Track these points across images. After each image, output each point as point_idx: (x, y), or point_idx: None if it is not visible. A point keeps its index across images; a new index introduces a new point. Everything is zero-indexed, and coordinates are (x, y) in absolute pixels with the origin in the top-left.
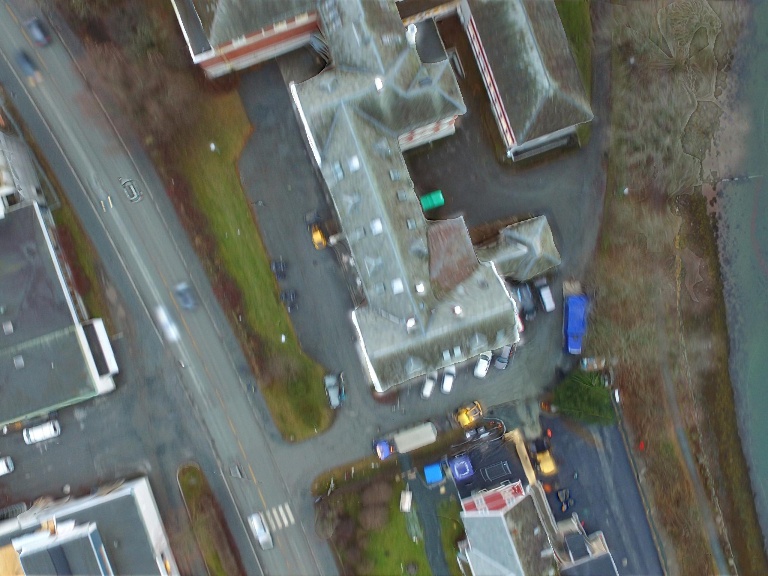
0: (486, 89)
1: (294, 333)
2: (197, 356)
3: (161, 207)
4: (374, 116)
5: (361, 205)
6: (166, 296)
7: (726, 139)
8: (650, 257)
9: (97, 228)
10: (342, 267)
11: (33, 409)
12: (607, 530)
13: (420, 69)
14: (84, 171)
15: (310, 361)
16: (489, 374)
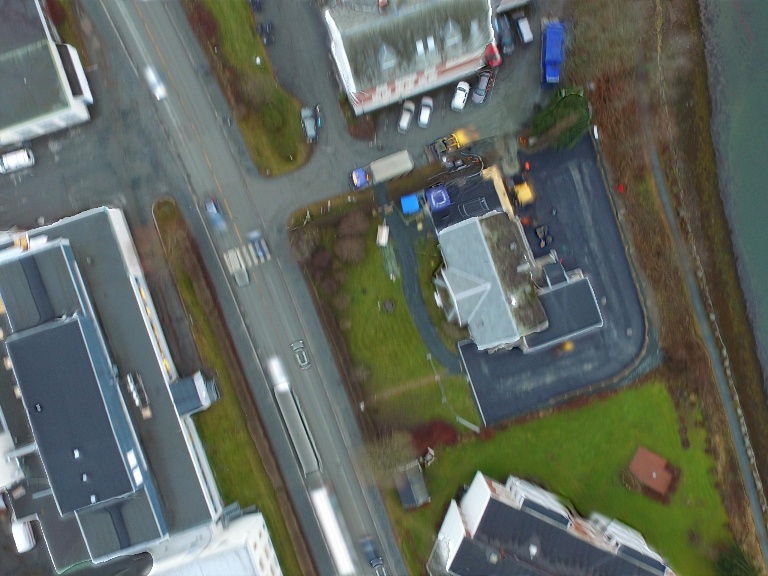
0: None
1: (270, 67)
2: (172, 88)
3: None
4: None
5: None
6: (141, 27)
7: None
8: (630, 4)
9: None
10: (318, 0)
11: (5, 124)
12: (586, 268)
13: None
14: None
15: (286, 95)
16: (467, 109)
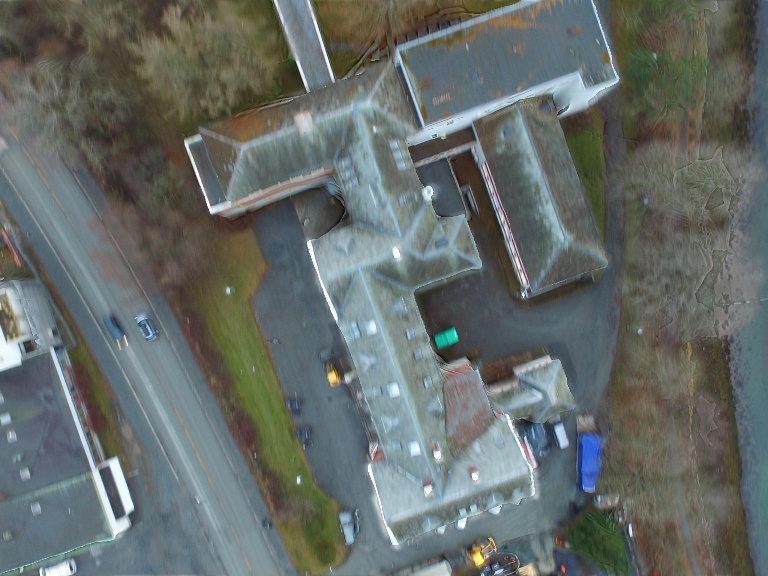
0: (500, 226)
1: (309, 469)
2: (212, 493)
3: (176, 346)
4: (391, 276)
5: (378, 366)
6: (181, 433)
7: (738, 262)
8: None
9: (113, 366)
10: (357, 403)
11: (50, 555)
12: None
13: (436, 226)
14: (100, 310)
15: (325, 497)
16: (503, 509)
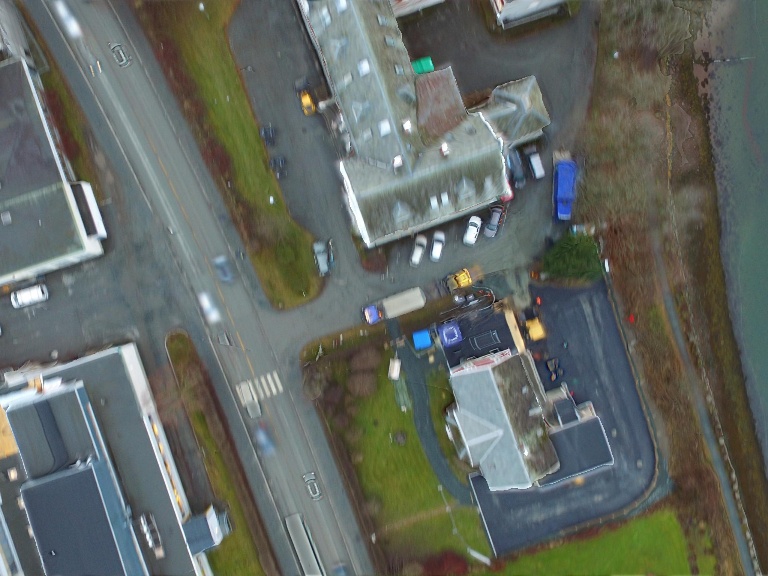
0: None
1: (283, 200)
2: (186, 222)
3: (150, 72)
4: None
5: (348, 48)
6: (155, 162)
7: (718, 20)
8: (641, 132)
9: (86, 93)
10: (331, 134)
11: (20, 266)
12: (596, 400)
13: None
14: (73, 35)
15: (299, 229)
16: (478, 243)
